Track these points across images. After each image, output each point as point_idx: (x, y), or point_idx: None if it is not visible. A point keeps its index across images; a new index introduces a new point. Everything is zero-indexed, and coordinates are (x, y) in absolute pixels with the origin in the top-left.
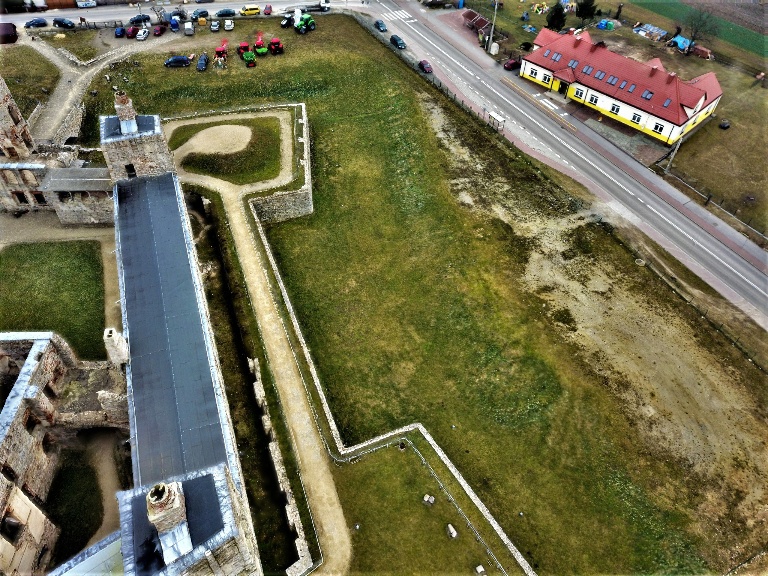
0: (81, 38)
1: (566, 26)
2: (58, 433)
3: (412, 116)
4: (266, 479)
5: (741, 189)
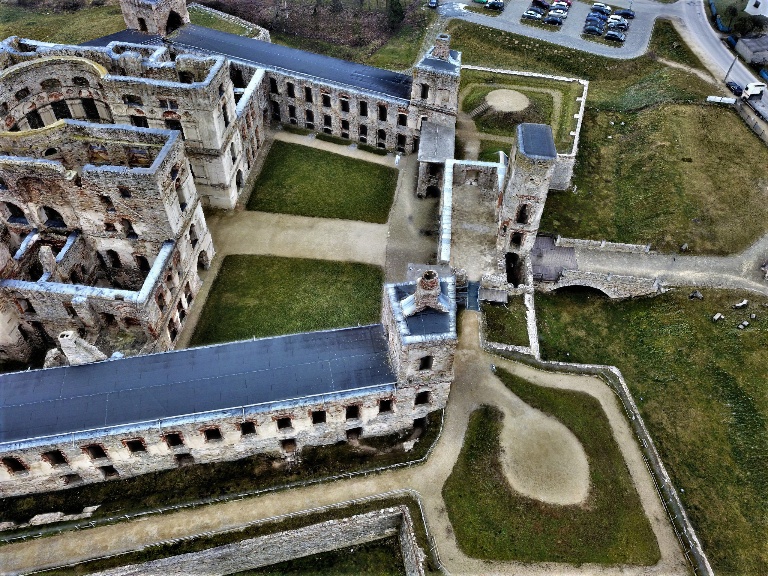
0: None
1: None
2: None
3: None
4: None
5: None
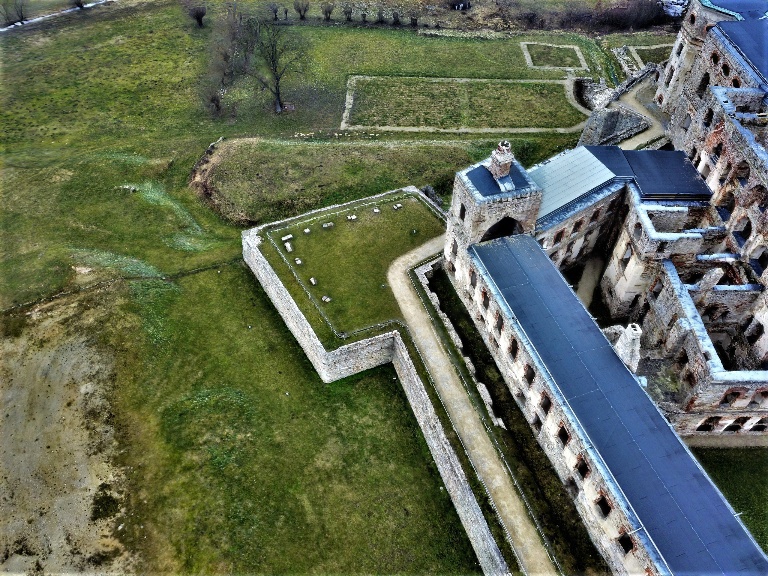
0: None
1: None
2: None
3: None
4: (460, 333)
5: None
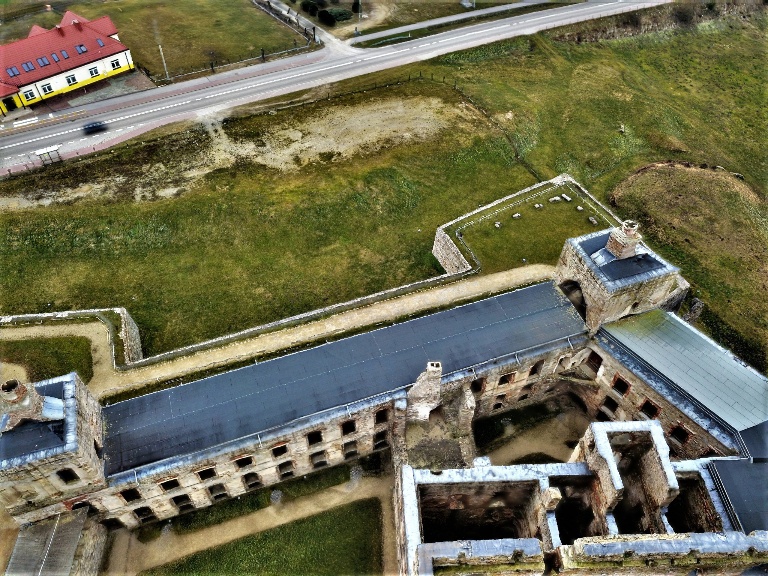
0: None
1: None
2: None
3: None
4: None
5: (199, 54)
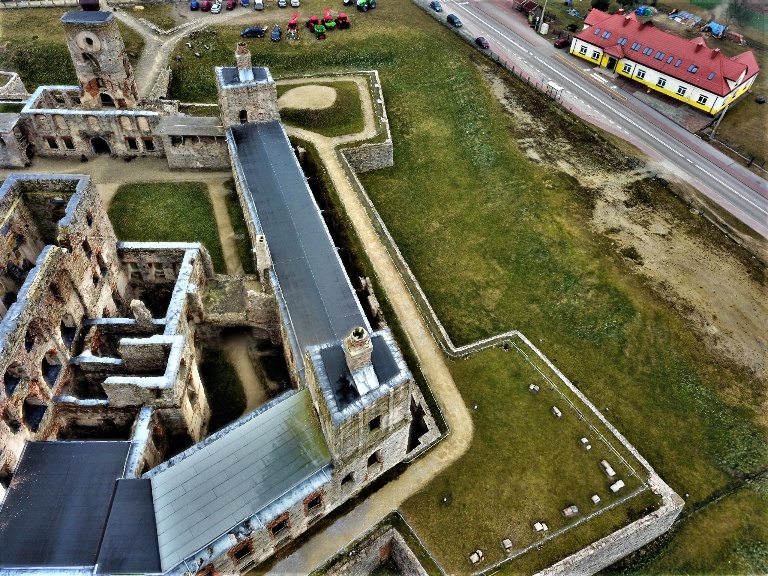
0: (159, 10)
1: (607, 12)
2: (204, 331)
3: (475, 85)
4: None
5: None
